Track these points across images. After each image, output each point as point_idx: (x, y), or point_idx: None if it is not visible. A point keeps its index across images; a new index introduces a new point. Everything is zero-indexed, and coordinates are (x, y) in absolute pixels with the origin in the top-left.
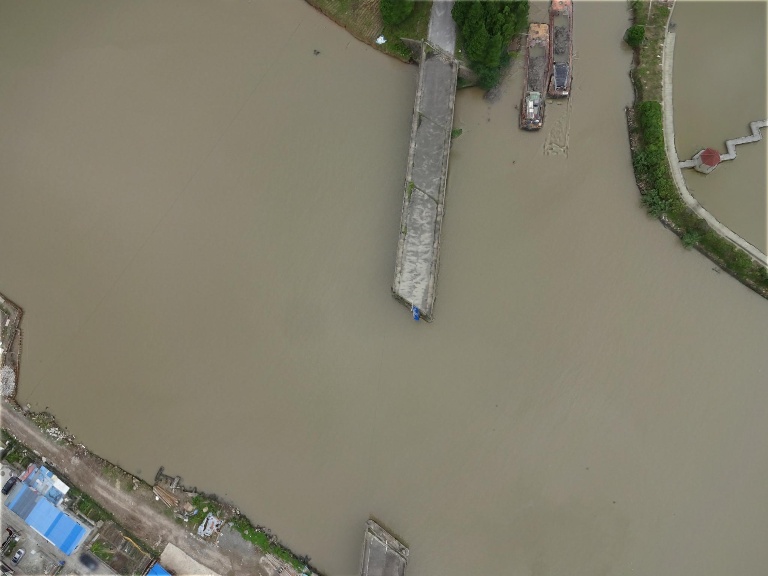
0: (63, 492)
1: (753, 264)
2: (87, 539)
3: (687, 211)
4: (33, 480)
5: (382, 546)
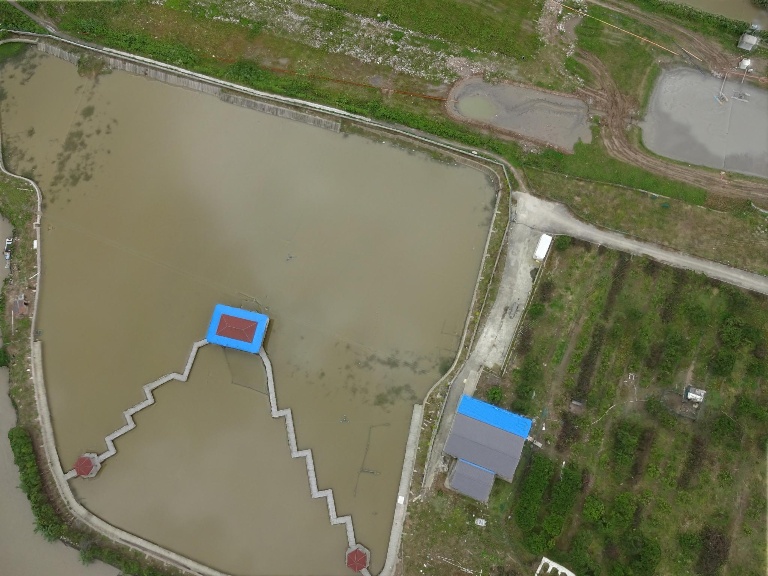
0: None
1: (148, 560)
2: None
3: (77, 525)
4: None
5: None
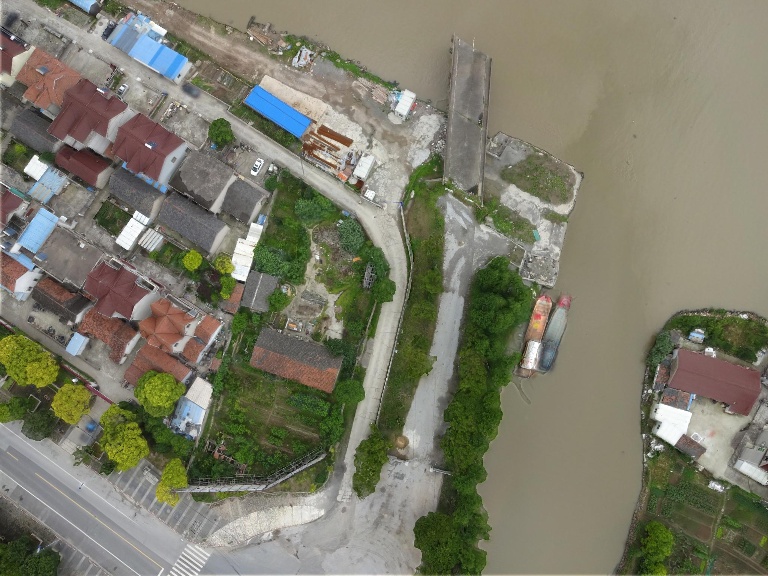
0: (161, 34)
1: None
2: (187, 75)
3: None
4: (132, 25)
5: (469, 46)
